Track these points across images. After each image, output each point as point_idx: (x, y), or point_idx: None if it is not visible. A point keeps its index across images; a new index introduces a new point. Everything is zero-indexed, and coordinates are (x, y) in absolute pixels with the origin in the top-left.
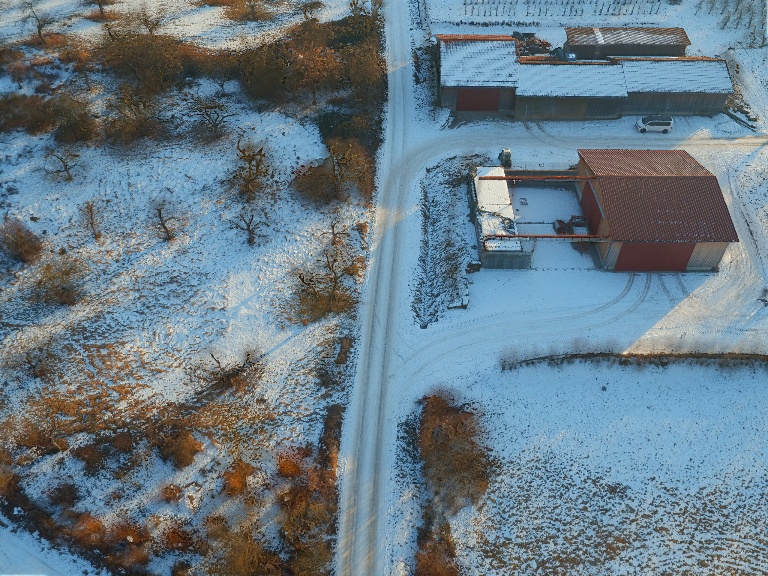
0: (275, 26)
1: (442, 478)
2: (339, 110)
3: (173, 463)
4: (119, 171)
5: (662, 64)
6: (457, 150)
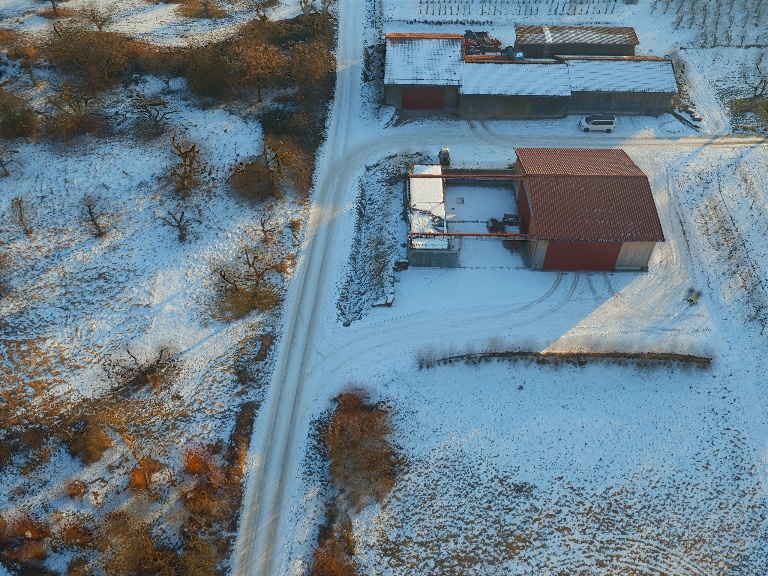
0: (228, 24)
1: (349, 476)
2: (284, 108)
3: (82, 459)
4: (57, 167)
5: (608, 63)
6: (398, 148)
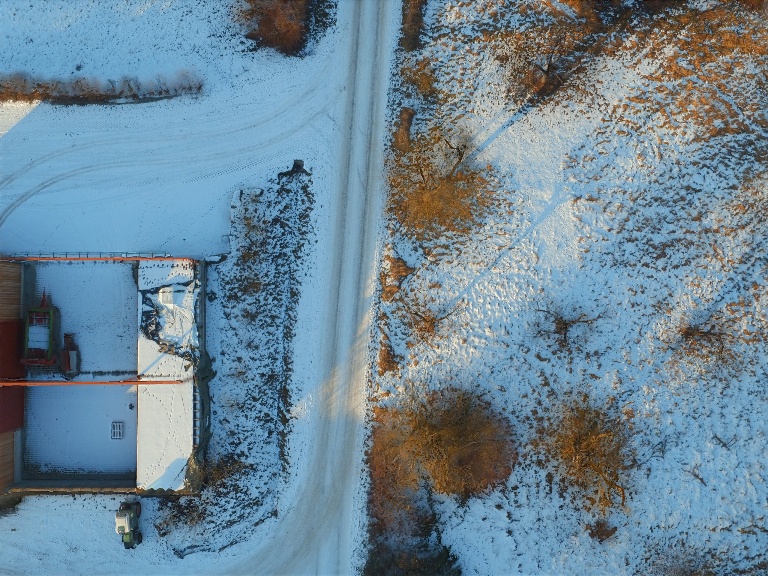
0: None
1: None
2: None
3: None
4: None
5: None
6: (216, 570)
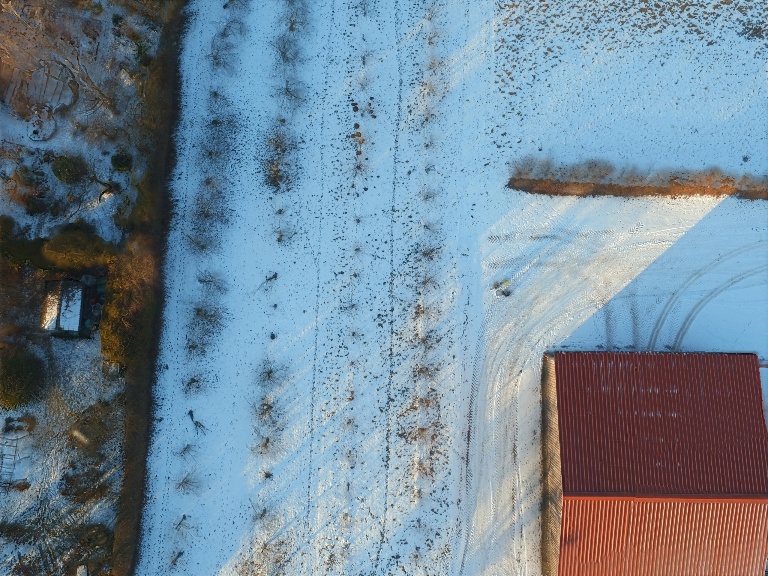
0: None
1: None
2: None
3: None
4: None
5: None
6: None
